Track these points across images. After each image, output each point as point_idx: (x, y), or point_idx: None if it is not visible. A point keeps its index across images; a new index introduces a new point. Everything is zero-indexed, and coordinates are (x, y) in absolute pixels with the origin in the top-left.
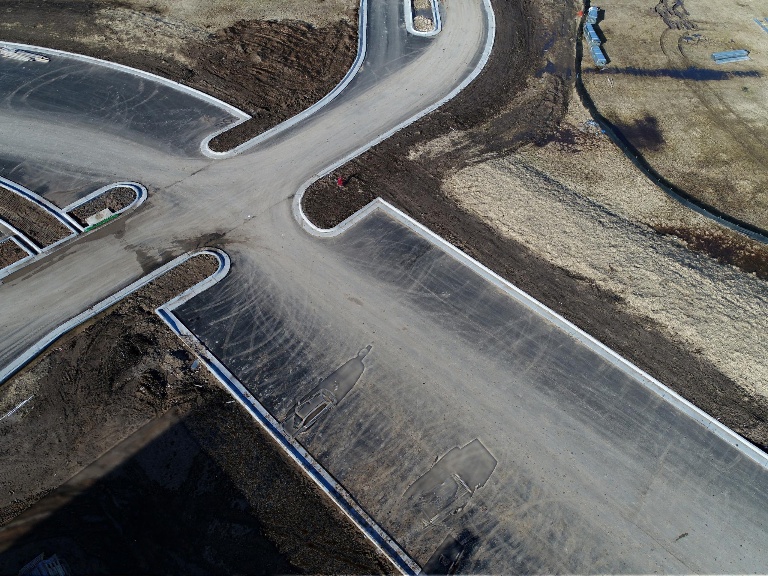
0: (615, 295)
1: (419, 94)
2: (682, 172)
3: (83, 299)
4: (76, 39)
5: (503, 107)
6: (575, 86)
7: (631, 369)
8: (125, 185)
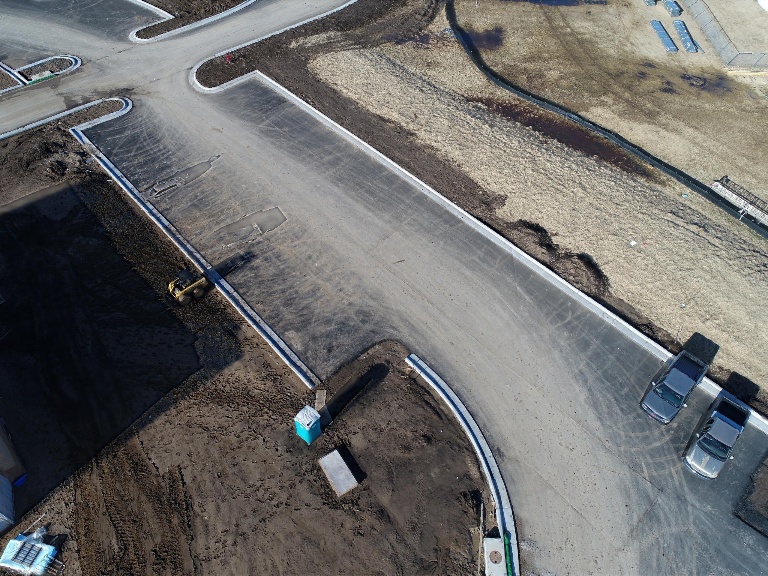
0: (412, 132)
1: (314, 7)
2: (506, 64)
3: (19, 122)
4: None
5: (381, 18)
6: (445, 5)
7: (405, 174)
8: (65, 57)
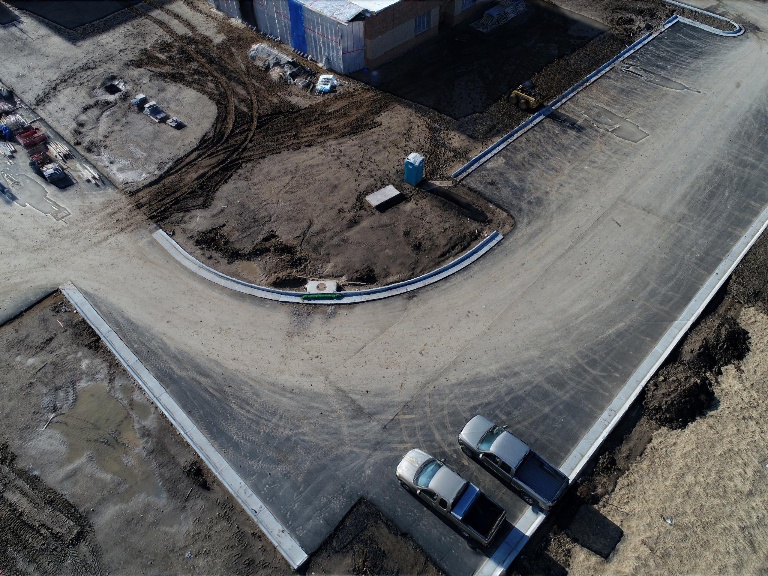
0: None
1: None
2: None
3: None
4: None
5: None
6: None
7: (765, 221)
8: None
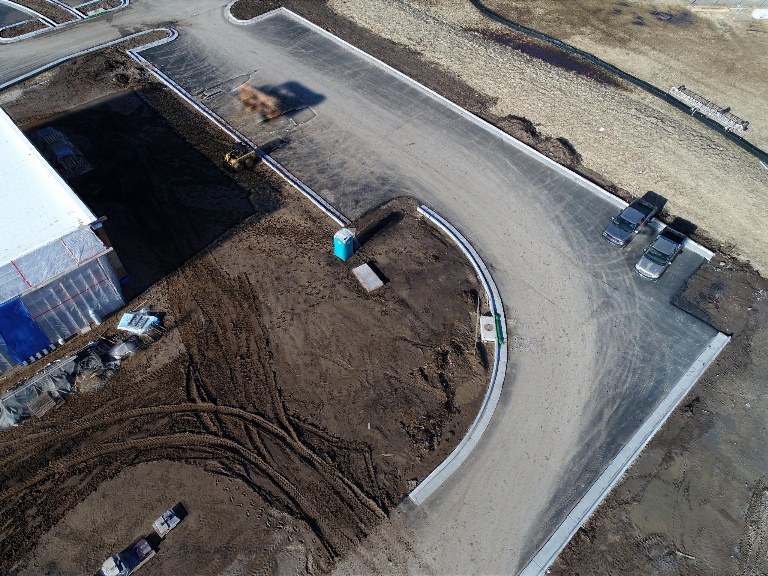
0: (418, 52)
1: None
2: (499, 3)
3: (83, 46)
4: None
5: None
6: None
7: (414, 83)
8: None
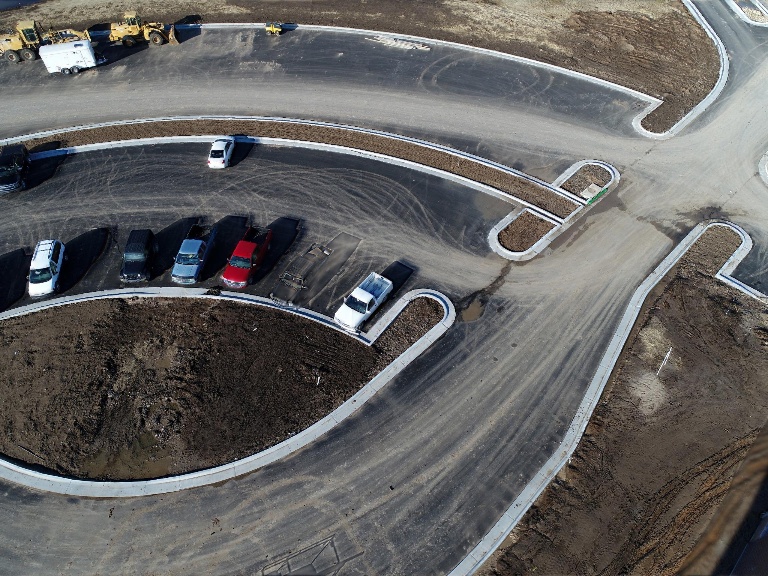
0: None
1: None
2: None
3: (638, 264)
4: (443, 29)
5: None
6: None
7: None
8: (593, 163)
